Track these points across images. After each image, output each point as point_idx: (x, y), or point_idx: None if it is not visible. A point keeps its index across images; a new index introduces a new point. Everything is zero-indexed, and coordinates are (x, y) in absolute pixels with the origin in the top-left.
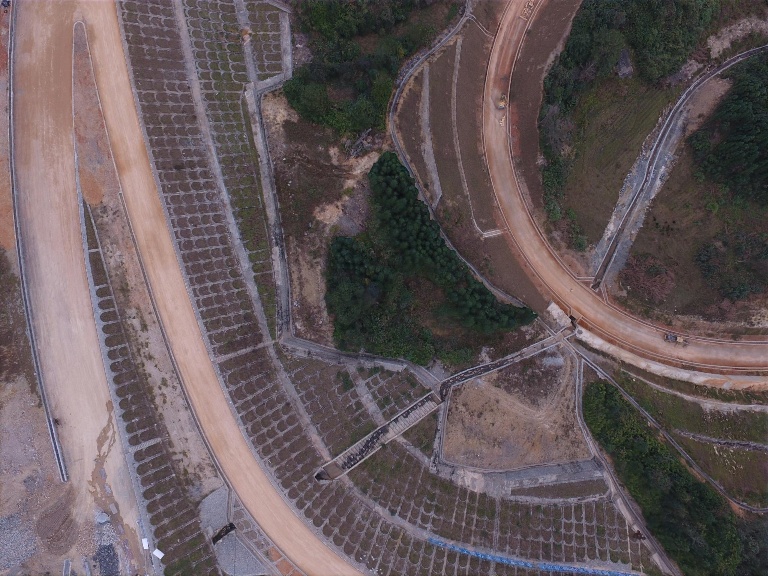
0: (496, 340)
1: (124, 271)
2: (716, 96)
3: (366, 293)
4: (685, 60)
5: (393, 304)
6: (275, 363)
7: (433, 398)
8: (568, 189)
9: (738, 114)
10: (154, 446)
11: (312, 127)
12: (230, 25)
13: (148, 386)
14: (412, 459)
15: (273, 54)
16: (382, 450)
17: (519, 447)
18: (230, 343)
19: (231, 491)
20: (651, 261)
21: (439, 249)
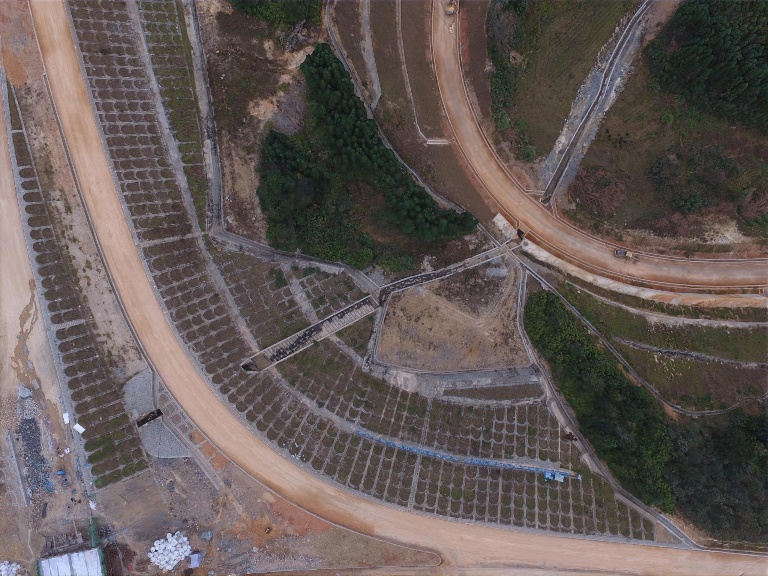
0: (439, 249)
1: (48, 153)
2: (675, 3)
3: (298, 188)
4: None
5: (331, 206)
6: (204, 254)
7: (371, 302)
8: (519, 99)
9: (693, 16)
10: (77, 327)
11: (246, 19)
12: None
13: (72, 268)
14: (345, 358)
15: None
16: (314, 347)
17: (455, 351)
18: (156, 229)
19: (155, 374)
20: (601, 173)
21: (375, 146)
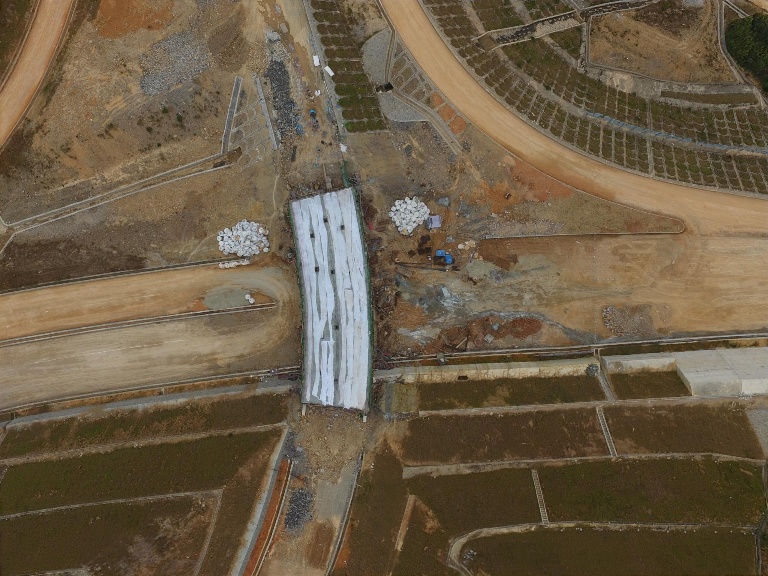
0: None
1: None
2: None
3: None
4: None
5: None
6: None
7: (575, 17)
8: None
9: None
10: None
11: None
12: None
13: None
14: (560, 58)
15: None
16: (532, 42)
17: (664, 64)
18: None
19: (394, 34)
20: None
21: None
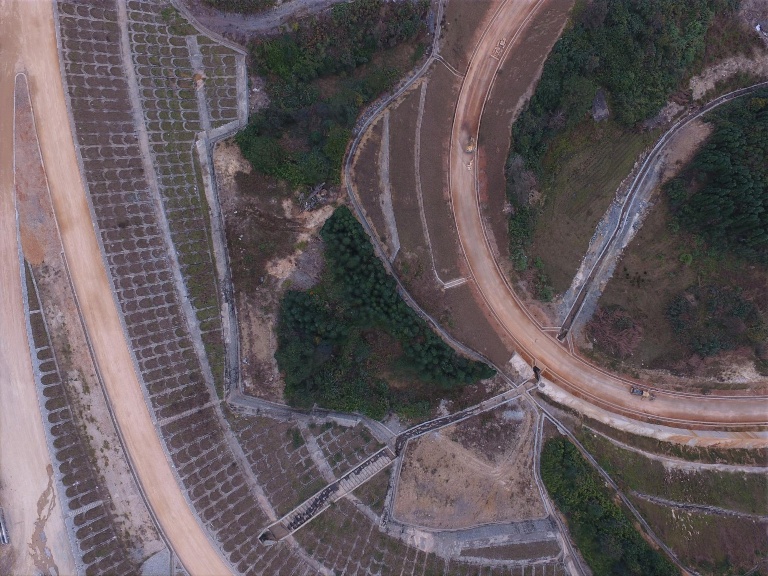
0: (455, 393)
1: (66, 332)
2: (695, 142)
3: (316, 352)
4: (664, 103)
5: (348, 358)
6: (222, 423)
7: (387, 453)
8: (536, 236)
9: (715, 166)
10: (95, 509)
11: (265, 179)
12: (183, 70)
13: (90, 448)
14: (361, 517)
15: (228, 99)
16: (331, 509)
17: (472, 505)
18: (174, 405)
19: (173, 554)
20: (619, 314)
21: (393, 307)
